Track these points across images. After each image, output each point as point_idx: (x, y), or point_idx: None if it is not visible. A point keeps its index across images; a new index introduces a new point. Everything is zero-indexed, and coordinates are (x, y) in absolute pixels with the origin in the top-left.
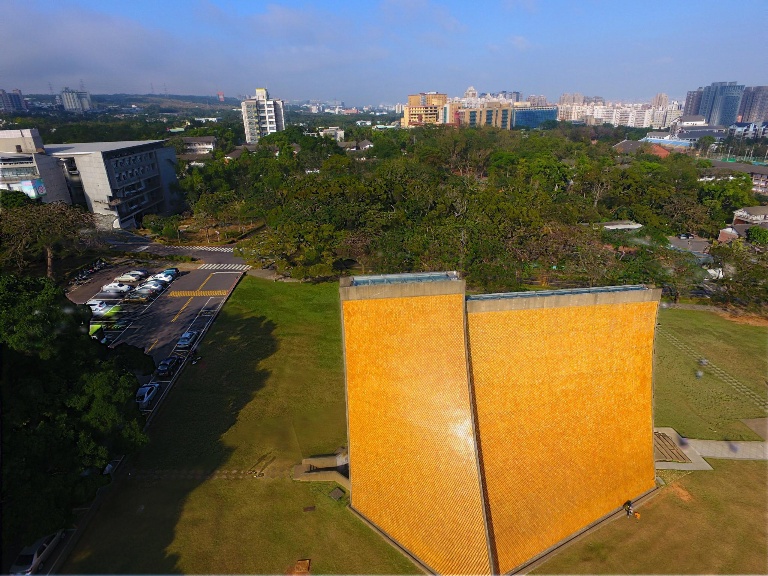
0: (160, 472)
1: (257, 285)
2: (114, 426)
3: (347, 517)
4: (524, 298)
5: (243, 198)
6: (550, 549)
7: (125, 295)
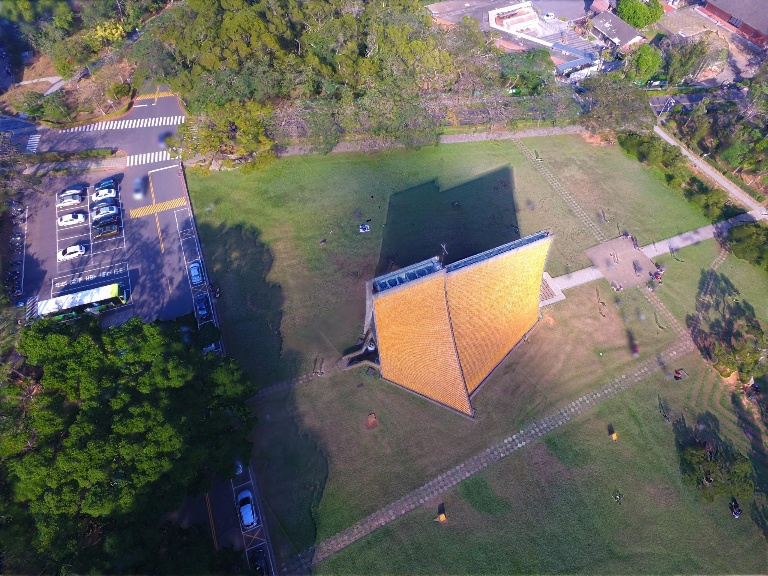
0: (261, 392)
1: (206, 182)
2: None
3: (383, 384)
4: (478, 263)
5: (97, 24)
6: (489, 373)
7: (88, 227)
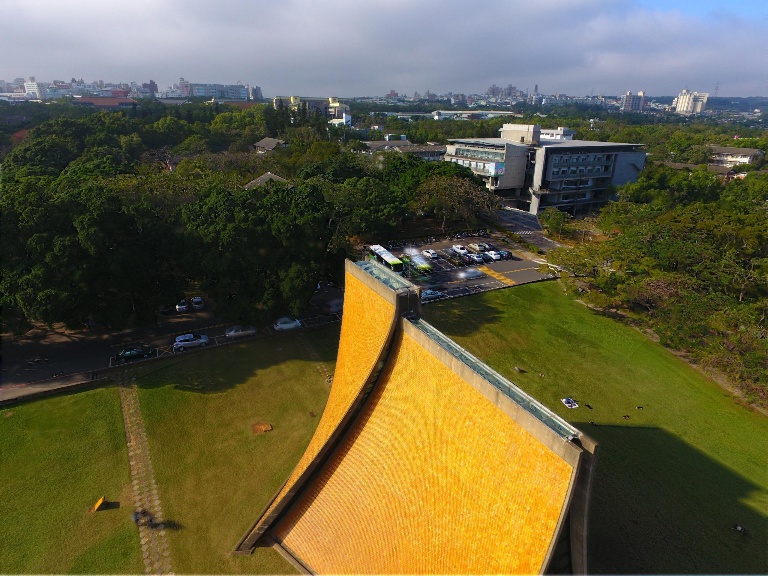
0: (308, 343)
1: (545, 290)
2: (288, 296)
3: None
4: (438, 345)
5: None
6: None
7: None
